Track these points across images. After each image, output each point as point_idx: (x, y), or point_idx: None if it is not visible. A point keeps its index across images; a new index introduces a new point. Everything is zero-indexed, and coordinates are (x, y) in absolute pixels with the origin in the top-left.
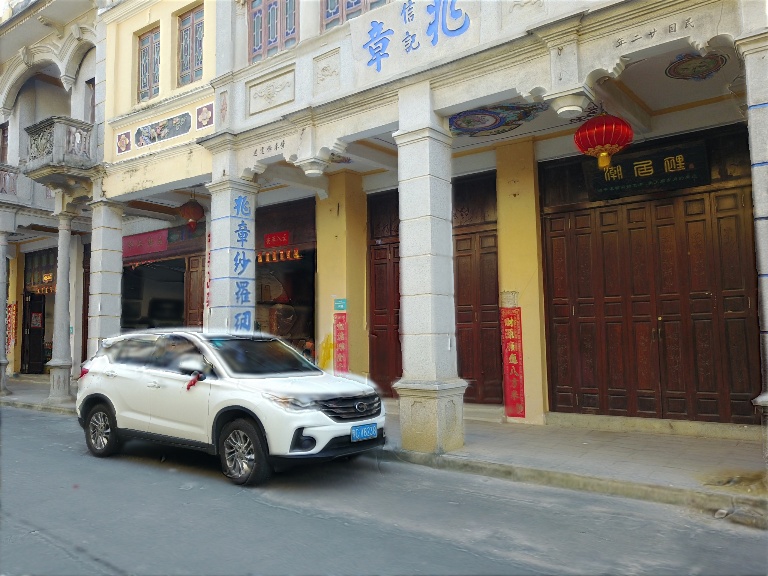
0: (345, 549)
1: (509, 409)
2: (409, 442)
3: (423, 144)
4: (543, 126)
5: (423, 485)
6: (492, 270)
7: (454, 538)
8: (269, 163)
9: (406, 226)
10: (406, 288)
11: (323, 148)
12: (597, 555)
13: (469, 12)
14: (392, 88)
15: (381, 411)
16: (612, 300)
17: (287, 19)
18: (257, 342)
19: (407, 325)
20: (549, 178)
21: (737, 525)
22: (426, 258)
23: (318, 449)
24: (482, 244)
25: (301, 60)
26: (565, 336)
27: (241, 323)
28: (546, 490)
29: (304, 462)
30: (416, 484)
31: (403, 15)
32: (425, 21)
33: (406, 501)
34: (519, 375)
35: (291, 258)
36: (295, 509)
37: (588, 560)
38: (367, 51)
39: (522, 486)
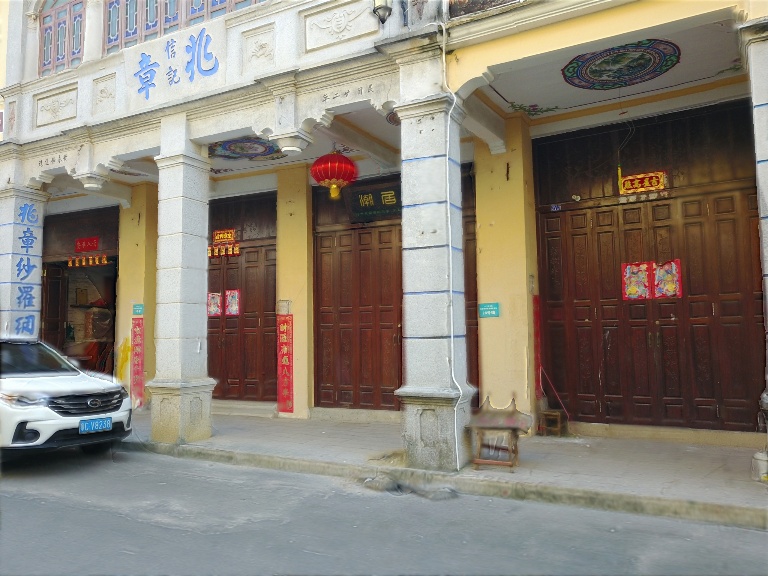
0: (21, 521)
1: (281, 405)
2: (157, 435)
3: (178, 169)
4: (310, 155)
5: (150, 471)
6: (274, 280)
7: (127, 508)
8: (56, 174)
9: (163, 241)
10: (161, 297)
11: (100, 164)
12: (229, 514)
13: (218, 56)
14: (156, 116)
15: (121, 407)
16: (365, 309)
17: (74, 39)
18: (15, 345)
19: (160, 330)
20: (321, 201)
21: (366, 488)
22: (177, 270)
23: (42, 441)
24: (267, 257)
25: (83, 80)
26: (329, 340)
27: (23, 327)
28: (254, 471)
29: (26, 453)
30: (145, 470)
31: (167, 51)
32: (184, 59)
33: (120, 484)
34: (290, 375)
35: (101, 263)
36: (6, 494)
37: (219, 517)
38: (138, 79)
39: (238, 468)
